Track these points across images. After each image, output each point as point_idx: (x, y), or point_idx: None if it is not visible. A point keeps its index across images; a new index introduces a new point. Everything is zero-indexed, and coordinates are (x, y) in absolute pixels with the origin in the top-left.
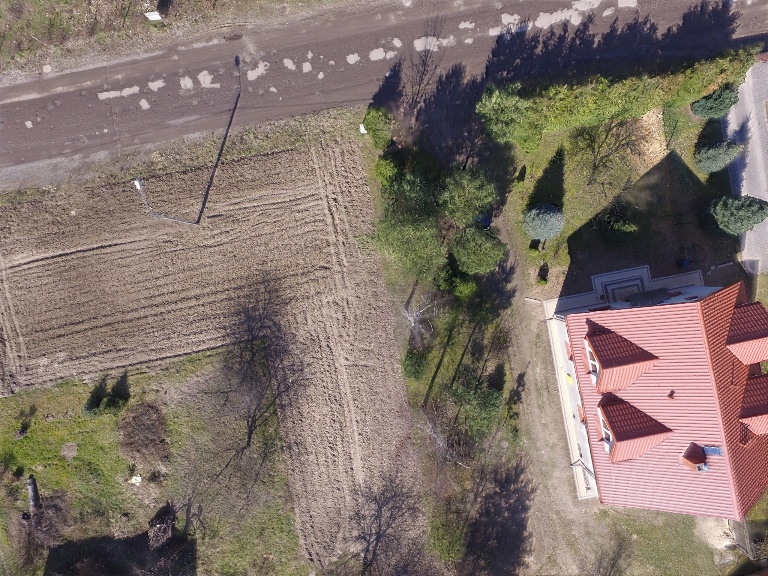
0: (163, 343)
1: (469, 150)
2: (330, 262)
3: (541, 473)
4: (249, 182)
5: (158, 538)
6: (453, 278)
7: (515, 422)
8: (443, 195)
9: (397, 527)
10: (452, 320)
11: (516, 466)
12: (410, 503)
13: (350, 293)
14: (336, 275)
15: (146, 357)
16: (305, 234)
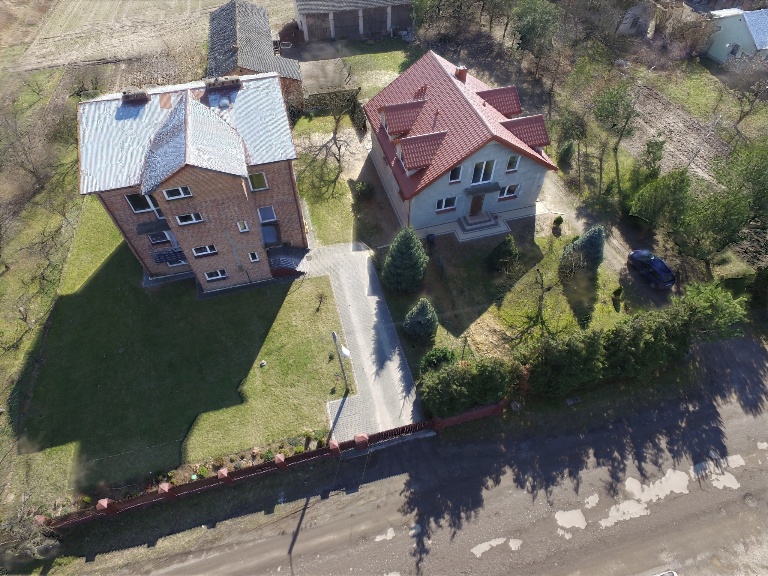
0: None
1: None
2: None
3: None
4: None
5: (762, 83)
6: None
7: None
8: None
9: None
10: None
11: None
12: None
13: None
14: None
15: None
16: None
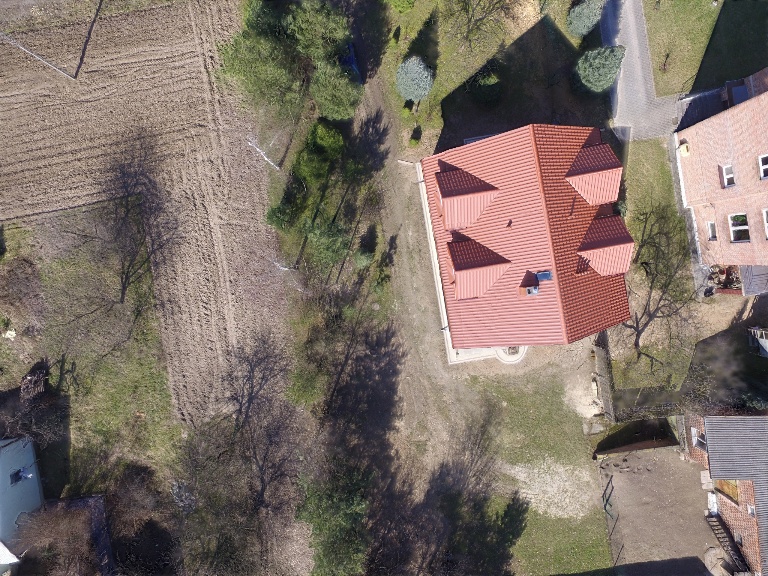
0: (39, 198)
1: (344, 10)
2: (205, 120)
3: (412, 337)
4: (126, 38)
5: (29, 390)
6: (317, 127)
7: (387, 285)
8: (286, 20)
9: (269, 389)
10: (317, 172)
11: (387, 329)
12: (282, 365)
13: (225, 152)
14: (211, 133)
15: (23, 212)
16: (181, 91)
